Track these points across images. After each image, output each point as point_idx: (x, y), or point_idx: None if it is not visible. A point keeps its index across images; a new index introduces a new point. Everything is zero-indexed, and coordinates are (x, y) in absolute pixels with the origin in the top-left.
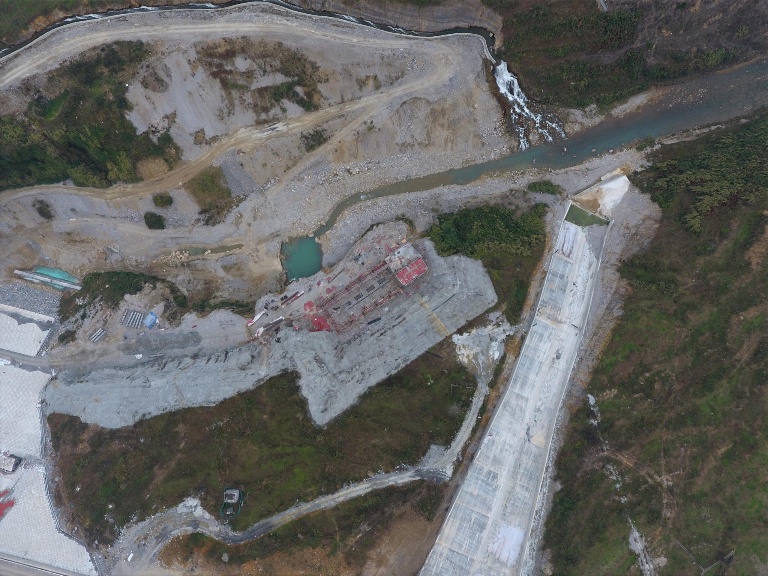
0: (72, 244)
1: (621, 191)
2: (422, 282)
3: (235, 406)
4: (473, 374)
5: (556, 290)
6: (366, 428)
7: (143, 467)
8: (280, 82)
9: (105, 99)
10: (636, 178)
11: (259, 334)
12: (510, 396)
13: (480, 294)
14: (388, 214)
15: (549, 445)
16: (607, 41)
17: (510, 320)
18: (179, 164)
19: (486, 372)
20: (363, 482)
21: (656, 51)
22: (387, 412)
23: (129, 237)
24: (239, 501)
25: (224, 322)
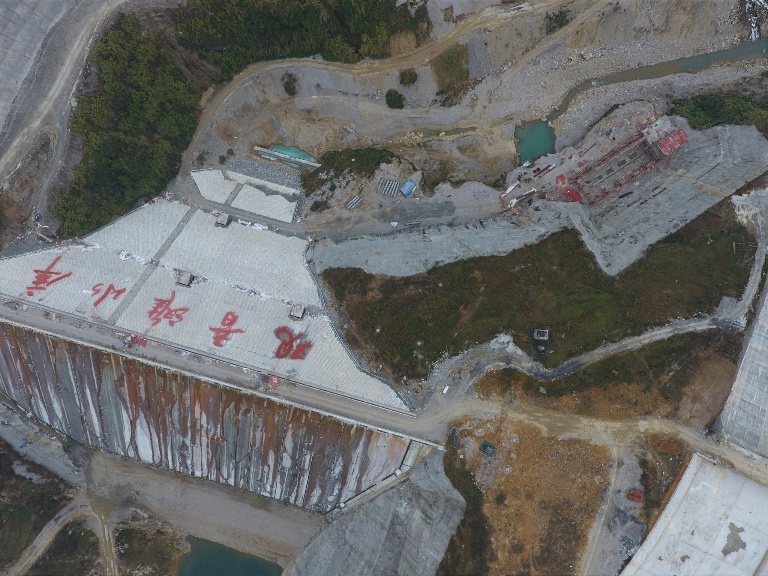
0: (311, 122)
1: None
2: (672, 158)
3: (525, 256)
4: (752, 234)
5: None
6: (657, 279)
7: (448, 307)
8: None
9: None
10: None
11: (512, 205)
12: None
13: (751, 160)
14: (622, 99)
15: None
16: None
17: None
18: (426, 41)
19: (765, 232)
20: (665, 326)
21: None
22: (675, 266)
23: (369, 116)
24: (547, 340)
25: (478, 193)
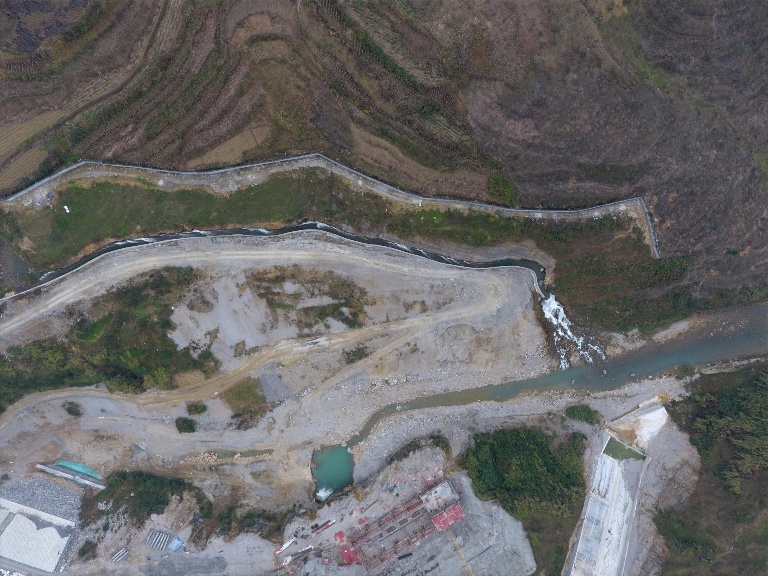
0: (98, 440)
1: (659, 423)
2: None
3: None
4: None
5: (591, 539)
6: None
7: None
8: (327, 303)
9: (149, 320)
10: (674, 411)
11: (287, 563)
12: None
13: (518, 554)
14: (424, 429)
15: None
16: (656, 281)
17: None
18: (216, 374)
19: None
20: None
21: (702, 288)
22: None
23: (158, 438)
24: None
25: (252, 548)
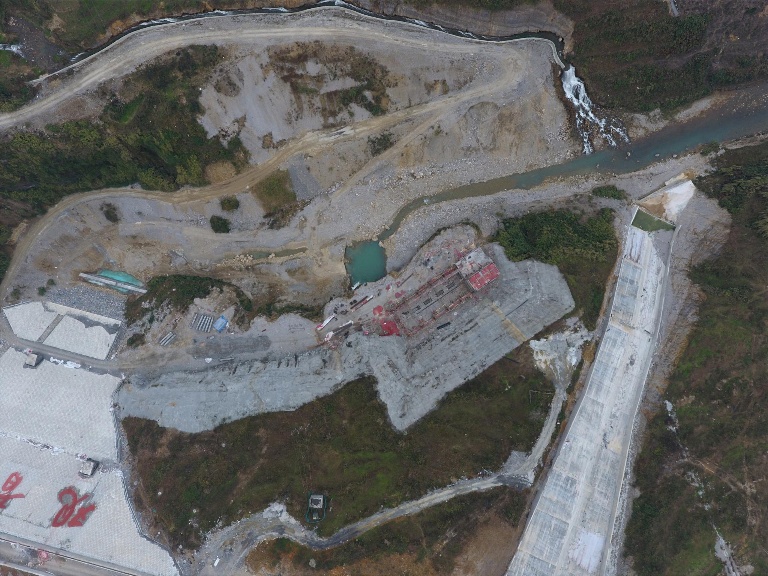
0: (137, 247)
1: (686, 196)
2: (491, 287)
3: (315, 411)
4: (551, 380)
5: (627, 295)
6: (446, 434)
7: (226, 472)
8: (349, 86)
9: (178, 103)
10: (702, 183)
11: (328, 338)
12: (586, 402)
13: (555, 299)
14: (452, 218)
15: (627, 451)
16: (676, 46)
17: (588, 326)
18: (246, 168)
19: (564, 378)
20: (447, 488)
21: (723, 56)
22: (467, 418)
23: (194, 240)
24: (324, 506)
25: (293, 326)
